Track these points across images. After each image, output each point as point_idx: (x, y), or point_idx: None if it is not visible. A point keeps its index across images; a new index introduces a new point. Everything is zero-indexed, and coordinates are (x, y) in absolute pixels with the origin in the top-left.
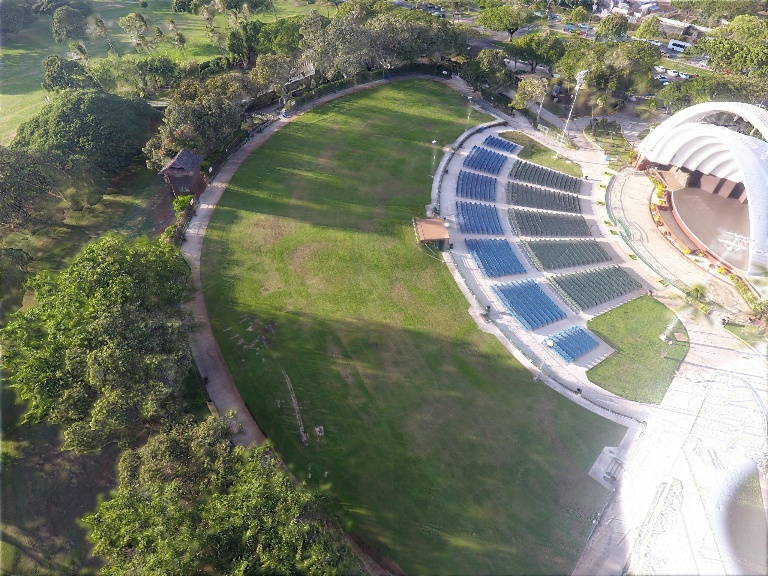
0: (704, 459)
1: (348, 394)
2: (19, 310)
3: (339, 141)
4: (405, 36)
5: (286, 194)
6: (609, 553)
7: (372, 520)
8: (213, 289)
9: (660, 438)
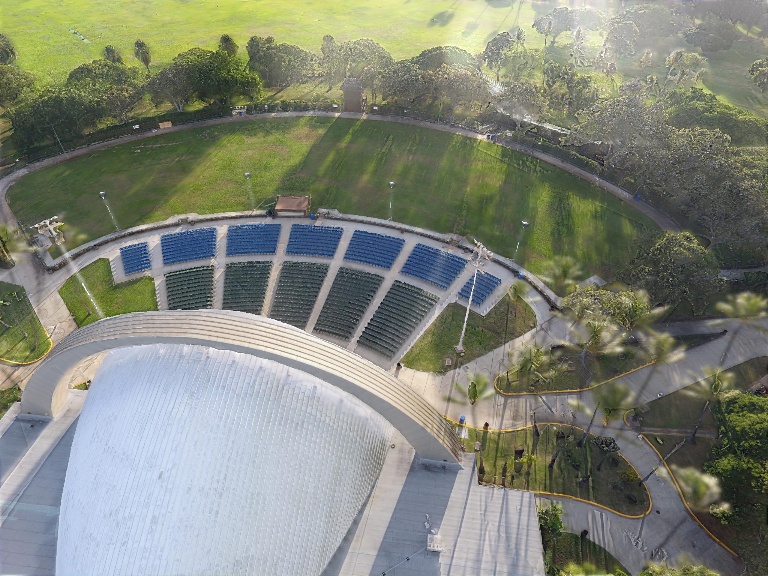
0: (8, 296)
1: (154, 160)
2: (284, 97)
3: (448, 164)
4: (659, 154)
5: (353, 141)
6: (6, 226)
7: (83, 160)
8: (253, 122)
9: (38, 278)
